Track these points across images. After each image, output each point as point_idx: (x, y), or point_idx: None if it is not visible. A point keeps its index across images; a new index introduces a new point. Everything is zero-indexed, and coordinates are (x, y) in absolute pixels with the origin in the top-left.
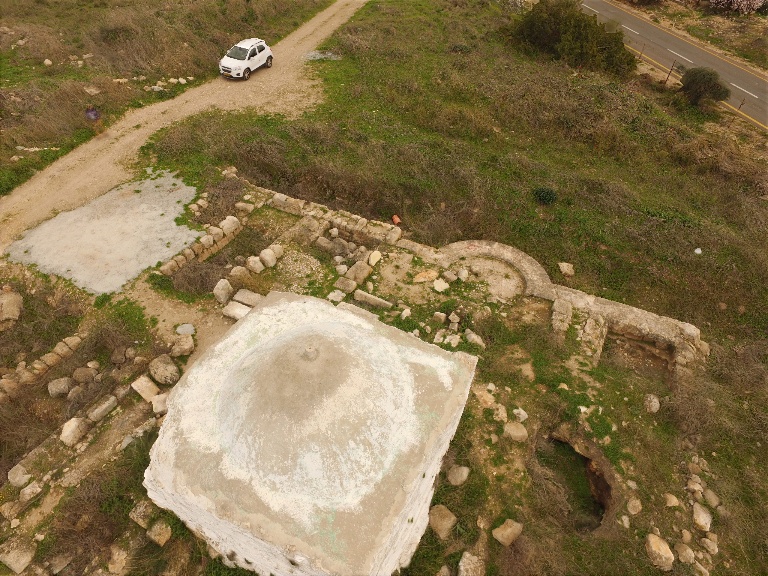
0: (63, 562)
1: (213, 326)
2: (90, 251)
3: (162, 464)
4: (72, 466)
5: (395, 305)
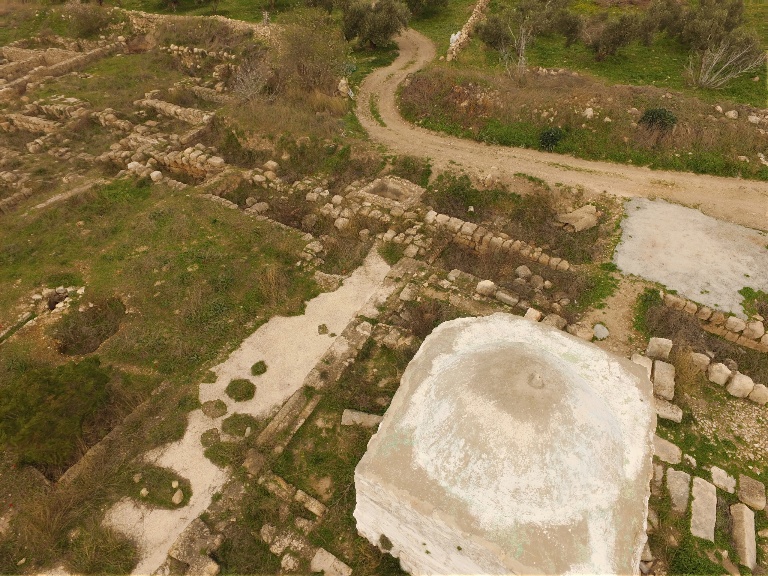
0: (406, 317)
1: (614, 352)
2: (661, 241)
3: (446, 323)
4: (463, 297)
5: (754, 575)
